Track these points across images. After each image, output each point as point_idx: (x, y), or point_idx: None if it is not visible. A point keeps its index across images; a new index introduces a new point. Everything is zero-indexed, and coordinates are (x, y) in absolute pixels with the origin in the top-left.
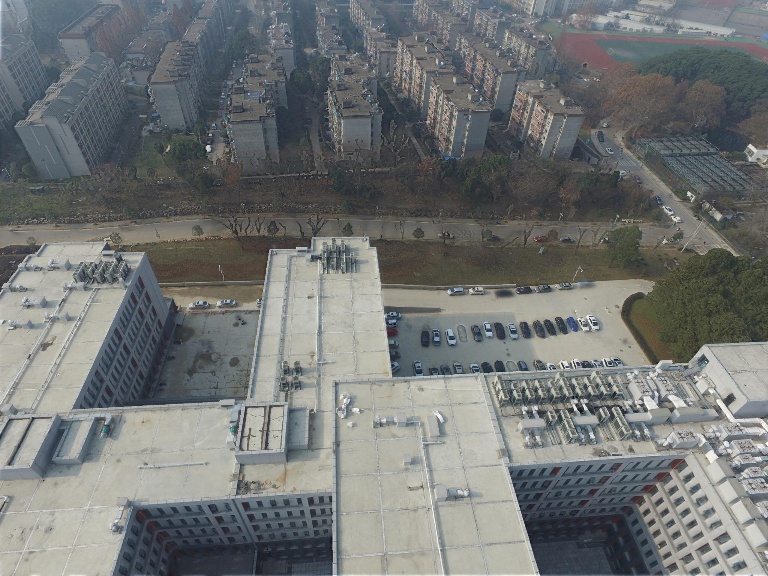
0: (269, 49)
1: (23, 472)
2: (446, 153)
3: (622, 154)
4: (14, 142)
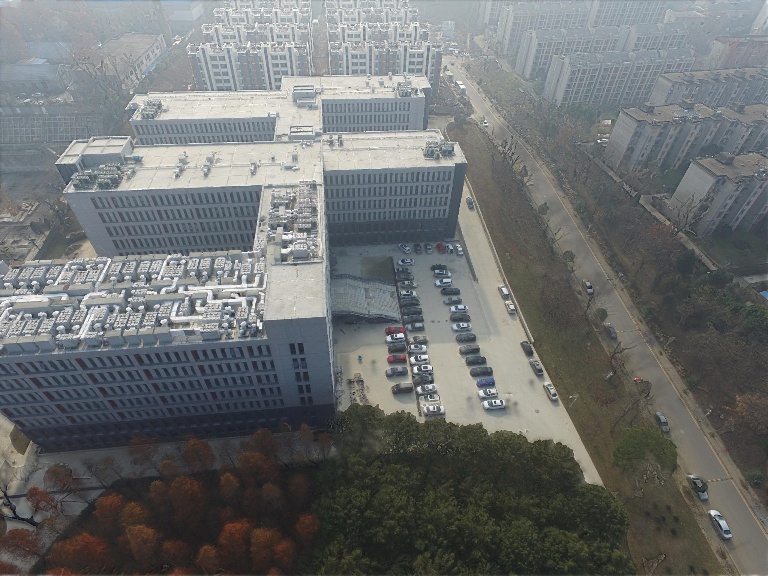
0: None
1: None
2: None
3: None
4: None
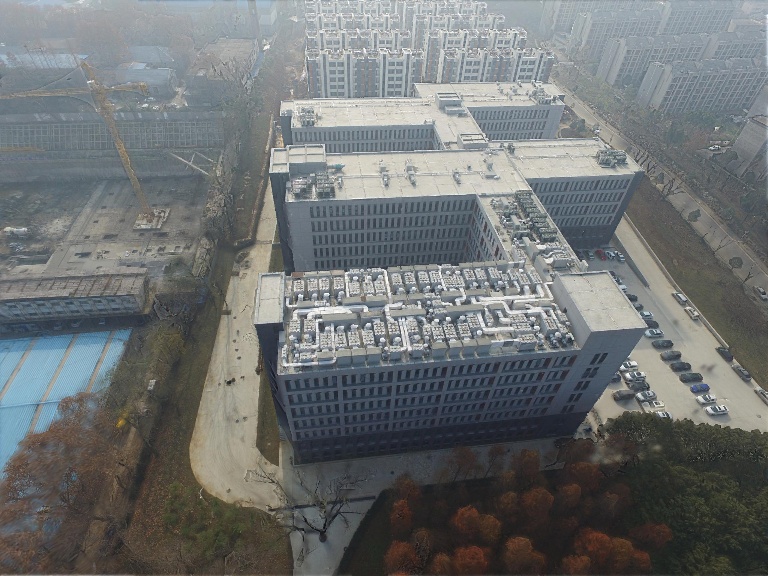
0: None
1: (438, 101)
2: None
3: None
4: None
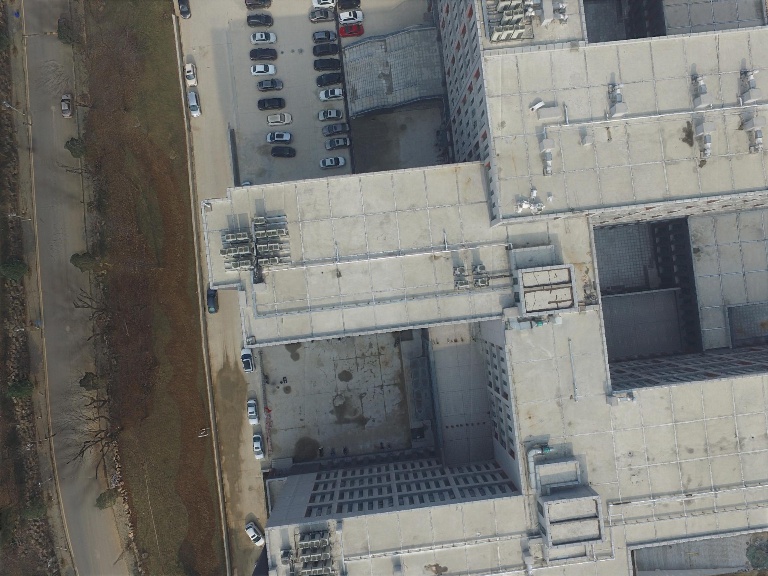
0: None
1: None
2: None
3: None
4: None
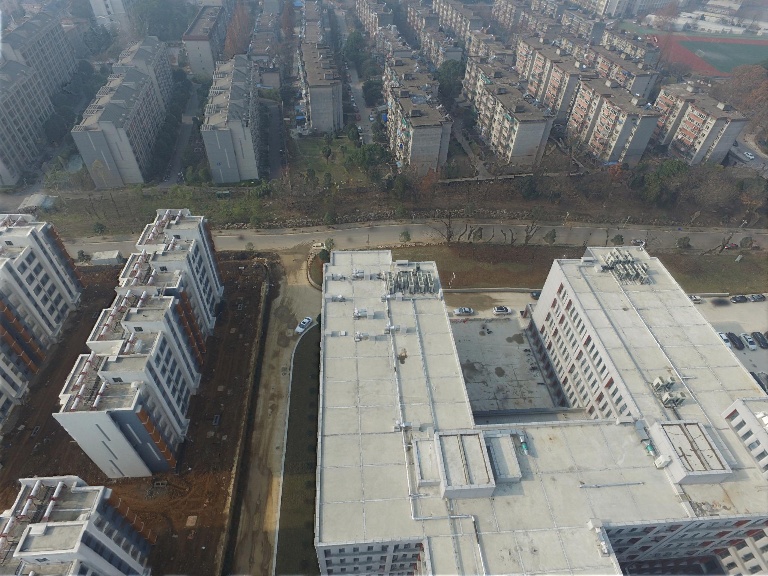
0: (371, 51)
1: (483, 491)
2: (602, 158)
3: (761, 159)
4: (172, 145)
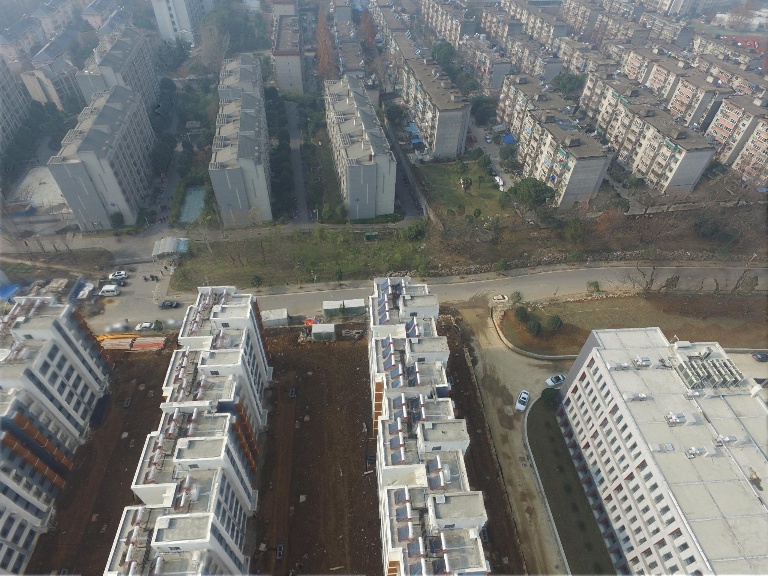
0: None
1: None
2: (753, 183)
3: None
4: None
